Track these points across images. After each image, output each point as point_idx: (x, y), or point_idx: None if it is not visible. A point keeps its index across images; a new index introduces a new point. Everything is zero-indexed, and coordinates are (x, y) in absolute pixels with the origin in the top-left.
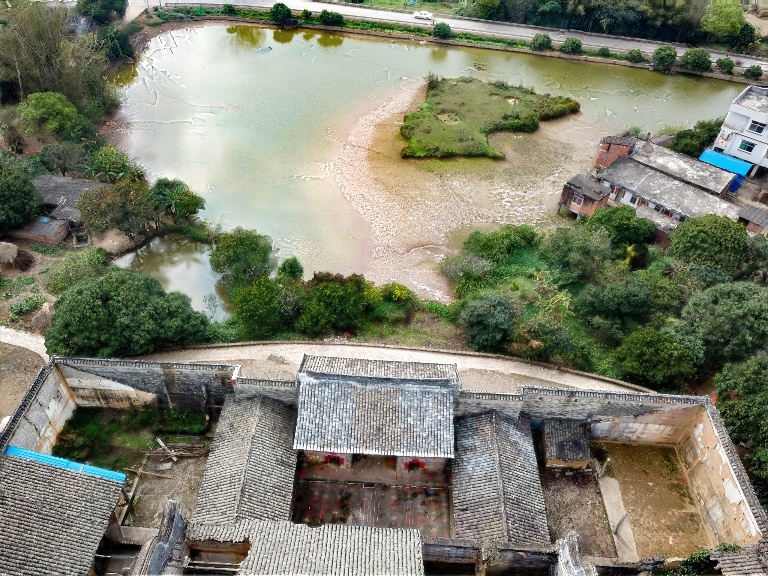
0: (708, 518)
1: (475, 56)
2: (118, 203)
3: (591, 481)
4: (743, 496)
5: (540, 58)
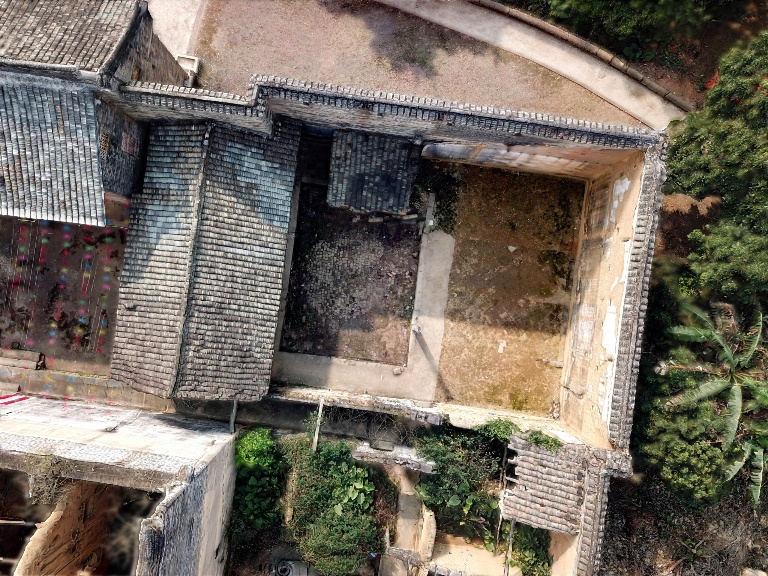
0: (575, 327)
1: None
2: None
3: (411, 235)
4: (615, 362)
5: None
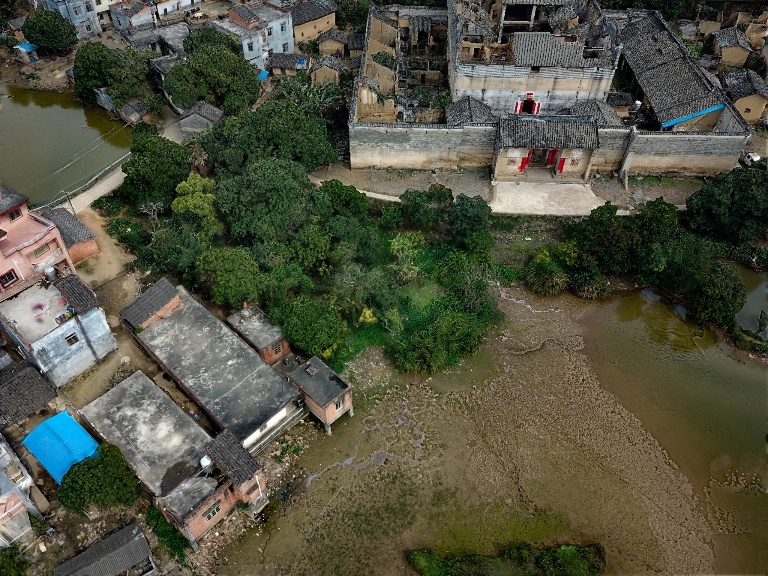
0: None
1: None
2: None
3: None
4: None
5: None
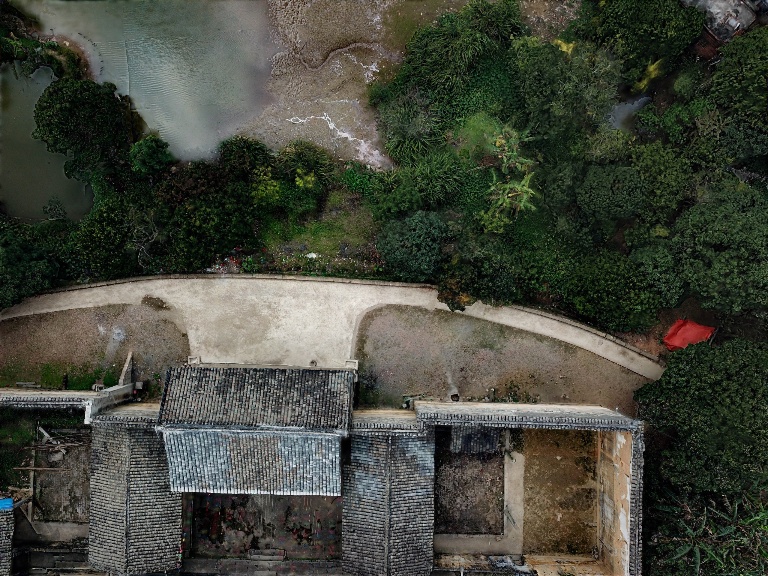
0: (602, 505)
1: None
2: None
3: (497, 455)
4: None
5: None
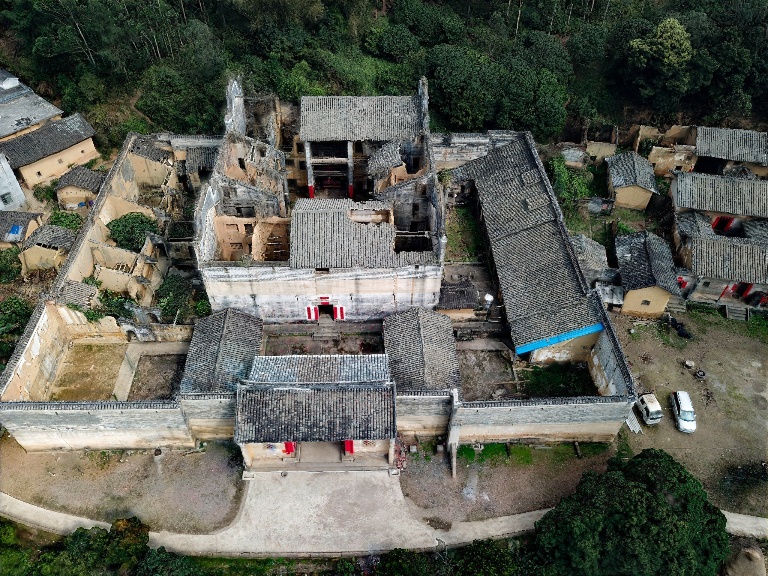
0: None
1: None
2: None
3: None
4: None
5: None
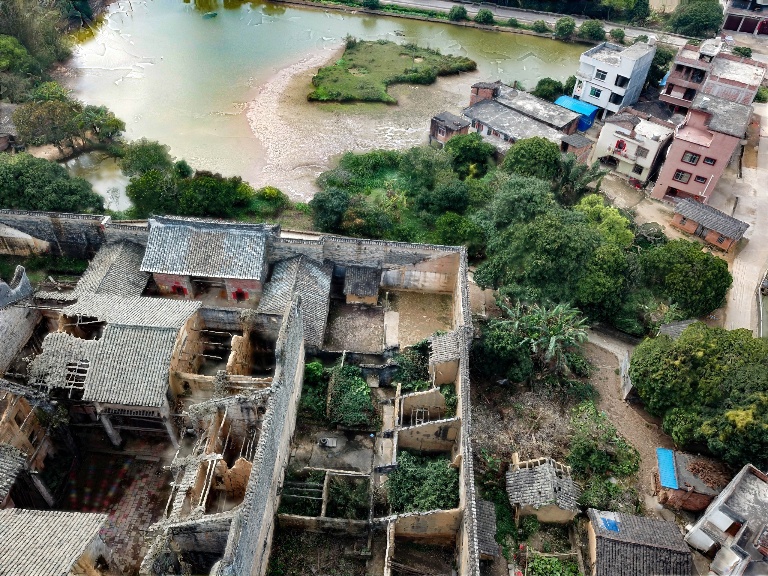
0: None
1: (402, 26)
2: (48, 119)
3: (380, 314)
4: (462, 303)
5: (456, 27)
